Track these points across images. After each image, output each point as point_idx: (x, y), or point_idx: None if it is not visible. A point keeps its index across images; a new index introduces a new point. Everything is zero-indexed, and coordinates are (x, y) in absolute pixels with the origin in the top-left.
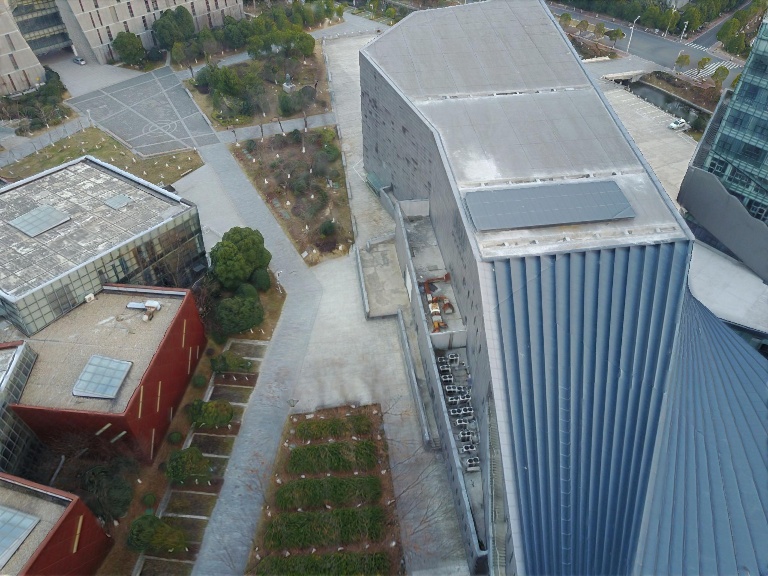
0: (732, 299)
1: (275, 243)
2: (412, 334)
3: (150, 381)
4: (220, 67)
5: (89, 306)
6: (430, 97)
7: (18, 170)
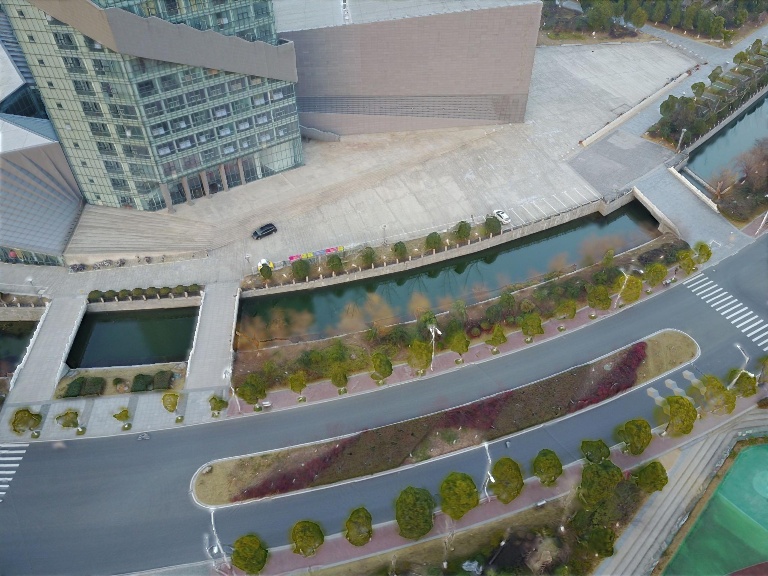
0: None
1: None
2: None
3: None
4: (573, 8)
5: None
6: None
7: None
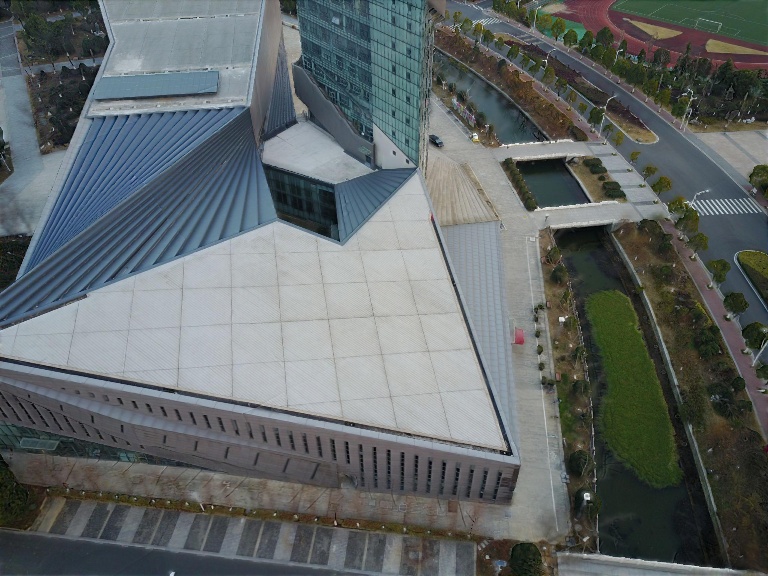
0: (311, 161)
1: (25, 140)
2: None
3: None
4: (54, 21)
5: None
6: (127, 20)
7: None
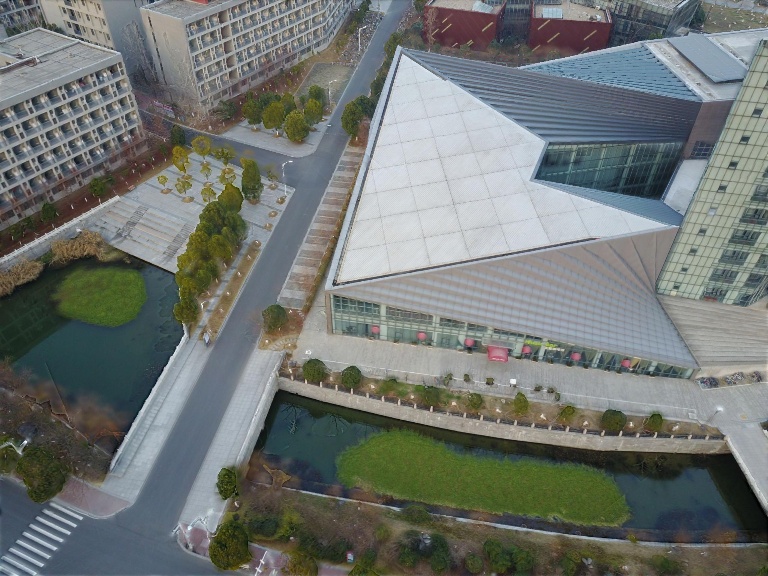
0: None
1: None
2: None
3: (555, 25)
4: None
5: (593, 9)
6: None
7: (717, 8)
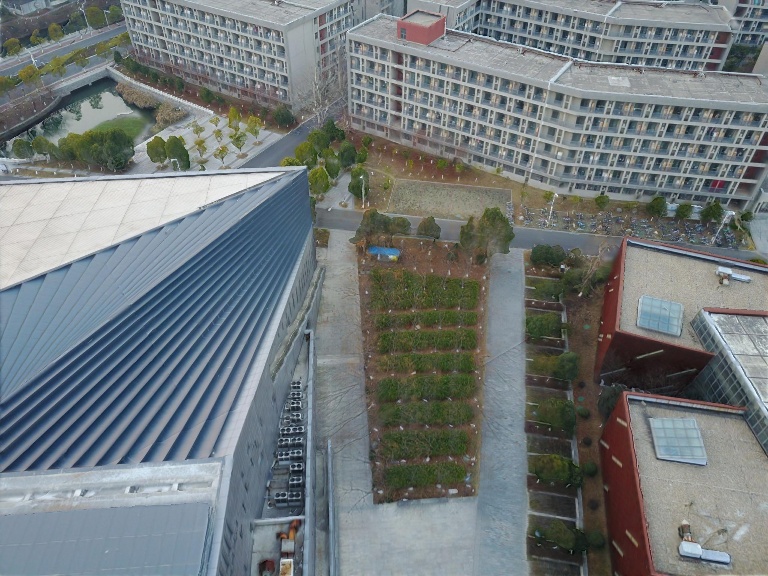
0: None
1: None
2: None
3: None
4: None
5: None
6: None
7: None
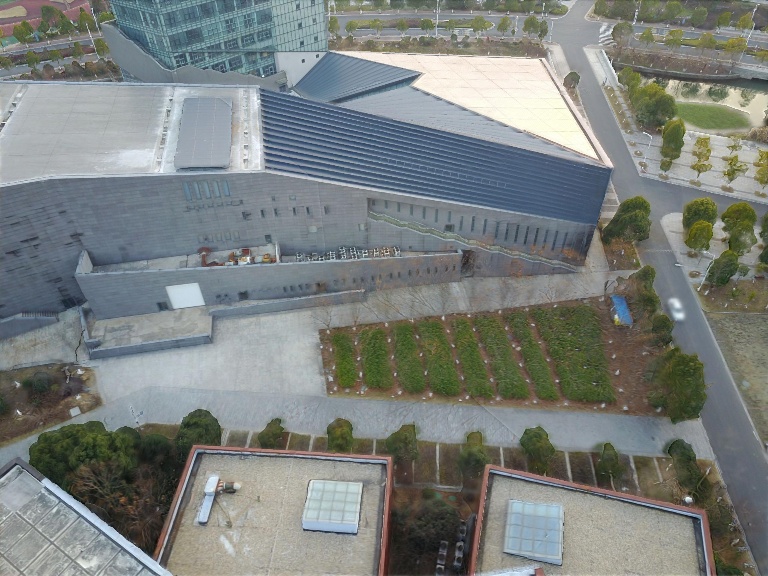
0: None
1: None
2: (243, 304)
3: None
4: None
5: None
6: None
7: None
